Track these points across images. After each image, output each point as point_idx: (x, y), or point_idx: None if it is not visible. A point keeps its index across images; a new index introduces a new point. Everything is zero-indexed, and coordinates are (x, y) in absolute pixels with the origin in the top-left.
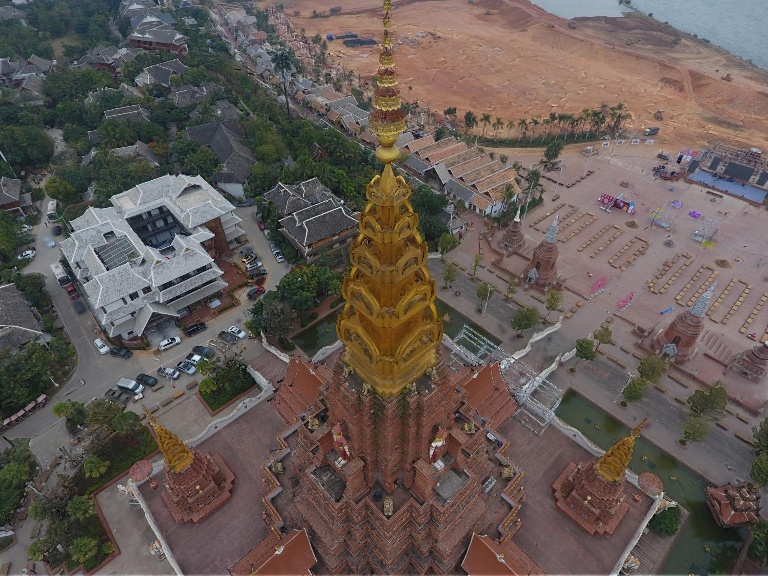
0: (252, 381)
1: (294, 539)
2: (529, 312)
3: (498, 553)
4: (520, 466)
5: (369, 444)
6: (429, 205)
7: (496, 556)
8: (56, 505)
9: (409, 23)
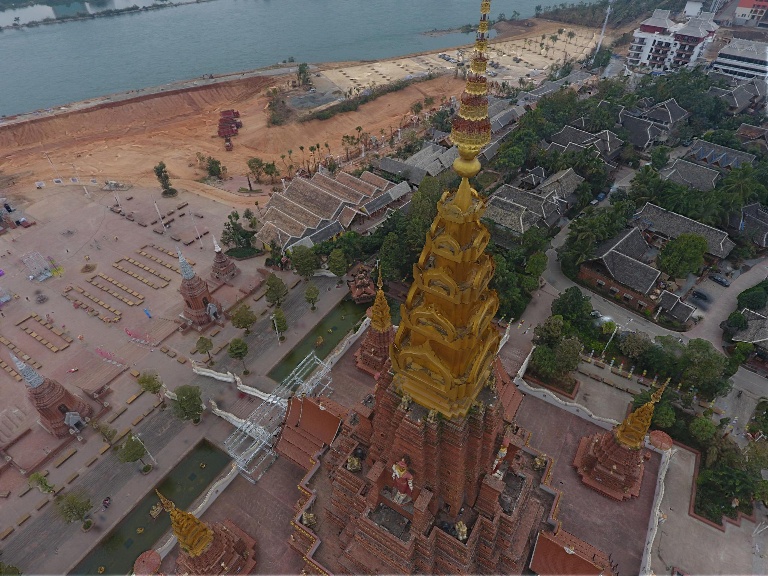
0: None
1: None
2: (187, 392)
3: None
4: None
5: None
6: None
7: None
8: None
9: None
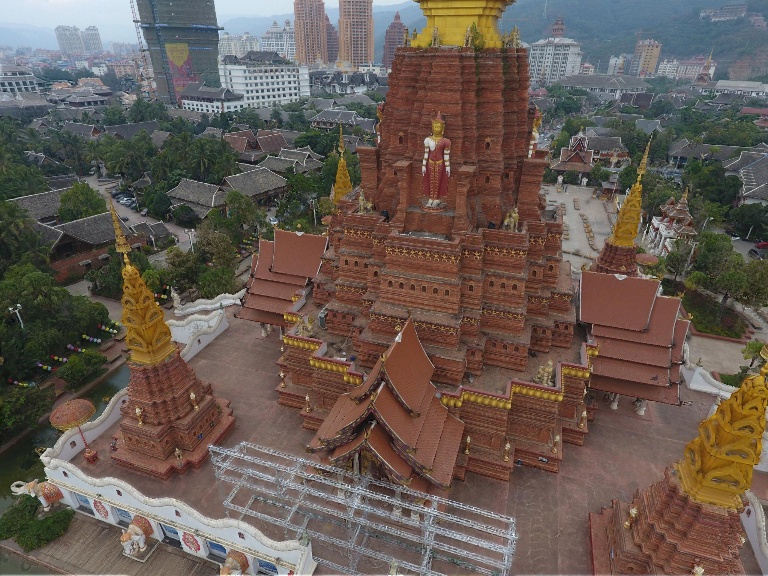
0: None
1: None
2: None
3: (302, 260)
4: (286, 436)
5: None
6: None
7: None
8: (670, 260)
9: None
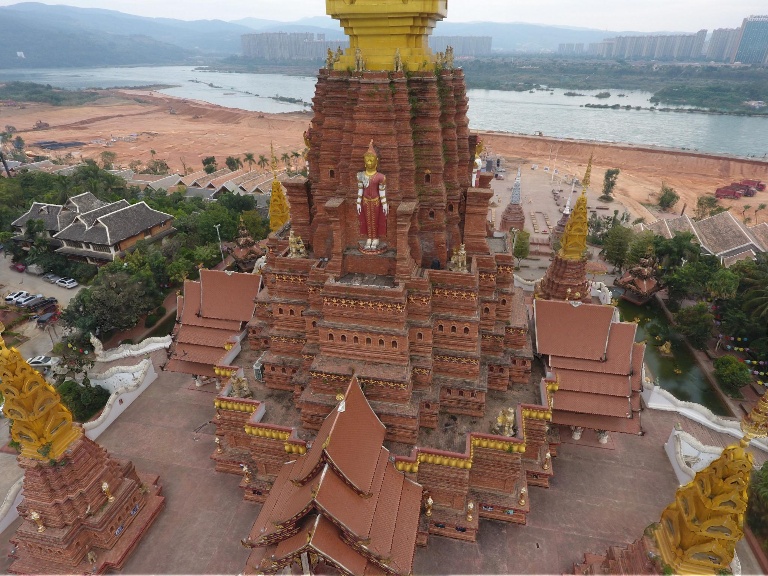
0: (105, 394)
1: (350, 391)
2: None
3: None
4: None
5: (413, 172)
6: (240, 205)
7: (570, 303)
8: None
9: (115, 129)
